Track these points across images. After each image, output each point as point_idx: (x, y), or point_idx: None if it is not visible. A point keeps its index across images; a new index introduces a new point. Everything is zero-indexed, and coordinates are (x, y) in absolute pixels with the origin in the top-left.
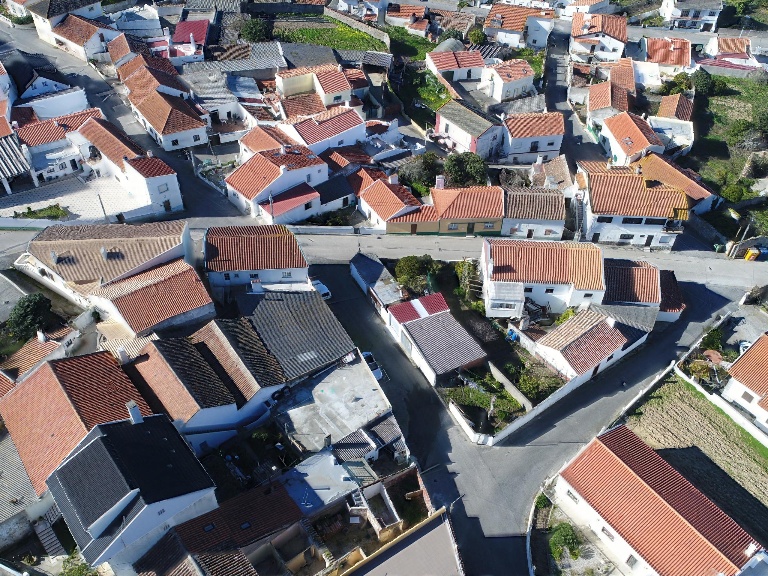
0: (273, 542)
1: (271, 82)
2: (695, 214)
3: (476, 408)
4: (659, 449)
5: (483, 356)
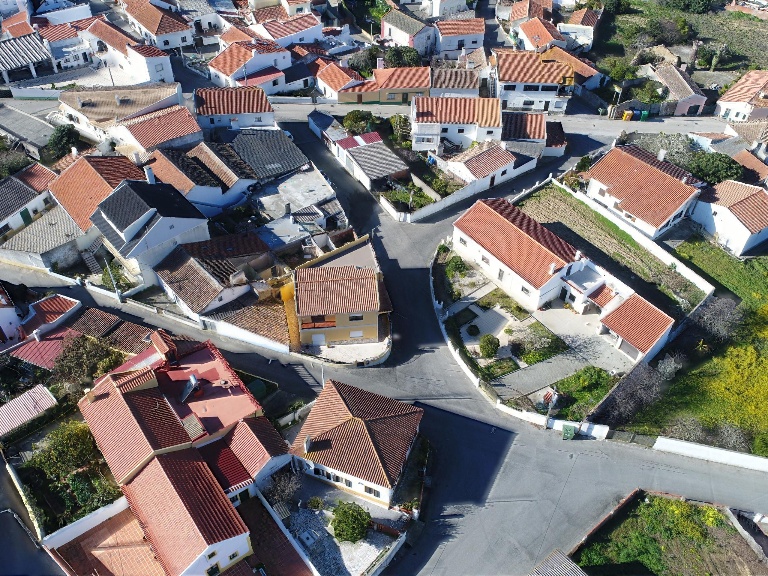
0: (250, 264)
1: (244, 2)
2: (585, 88)
3: None
4: None
5: (406, 169)
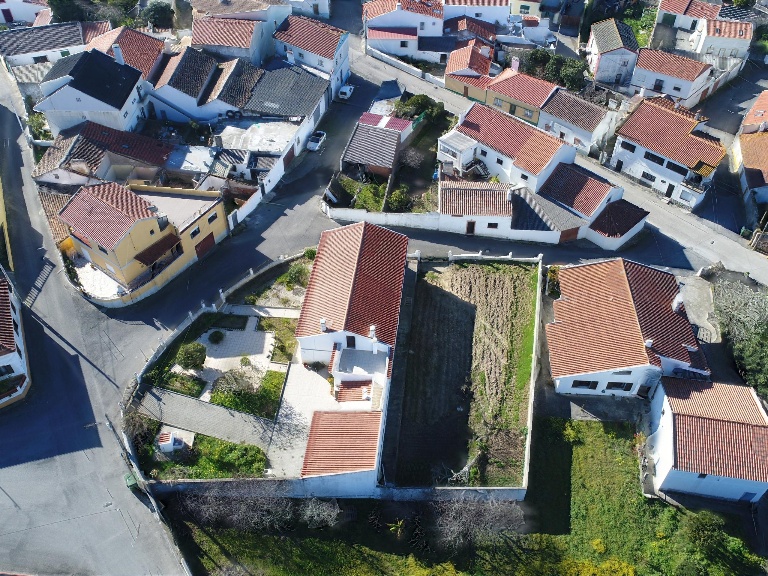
0: (137, 169)
1: None
2: (753, 195)
3: (351, 196)
4: (445, 290)
5: (388, 167)
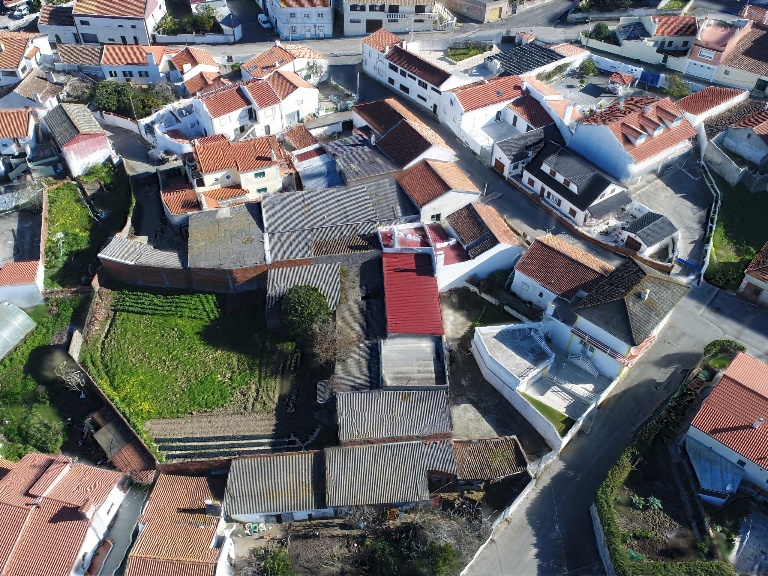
0: None
1: None
2: None
3: None
4: None
5: None
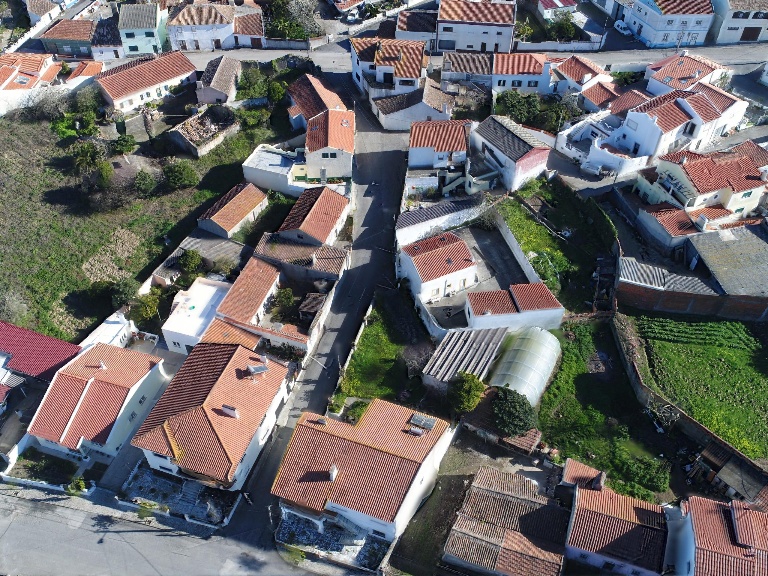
0: None
1: None
2: None
3: None
4: None
5: None
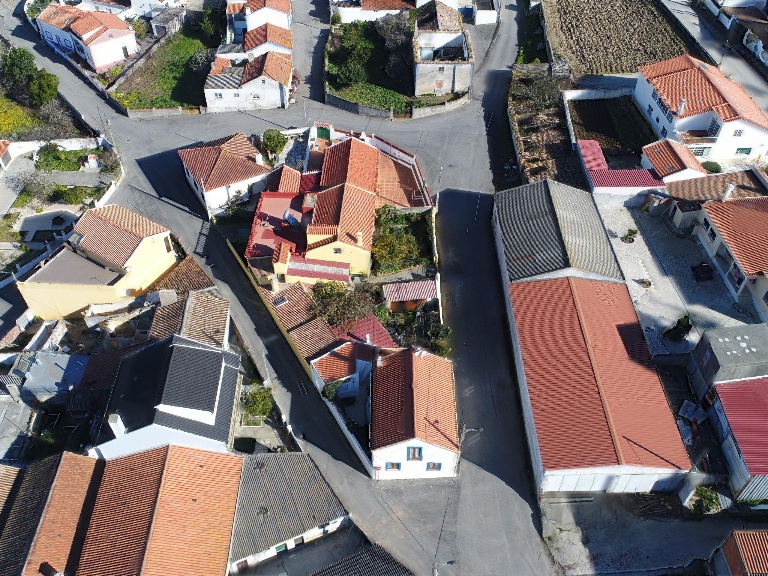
0: None
1: None
2: None
3: None
4: None
5: None
